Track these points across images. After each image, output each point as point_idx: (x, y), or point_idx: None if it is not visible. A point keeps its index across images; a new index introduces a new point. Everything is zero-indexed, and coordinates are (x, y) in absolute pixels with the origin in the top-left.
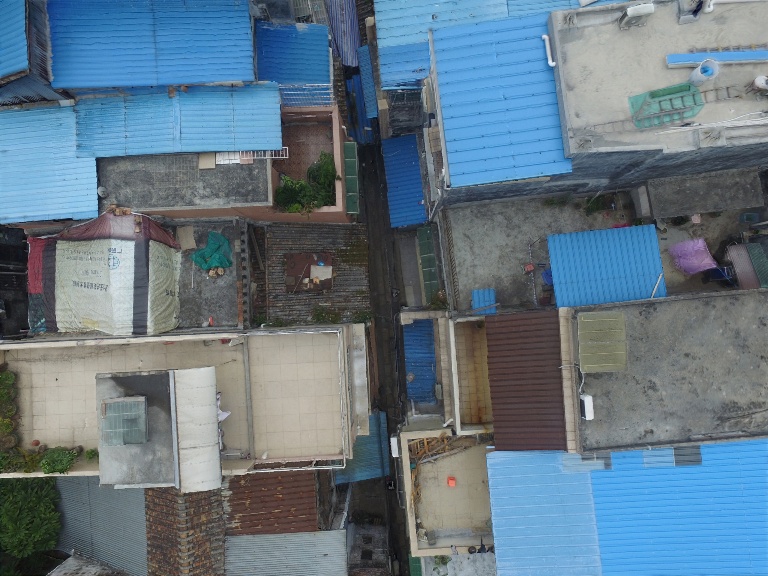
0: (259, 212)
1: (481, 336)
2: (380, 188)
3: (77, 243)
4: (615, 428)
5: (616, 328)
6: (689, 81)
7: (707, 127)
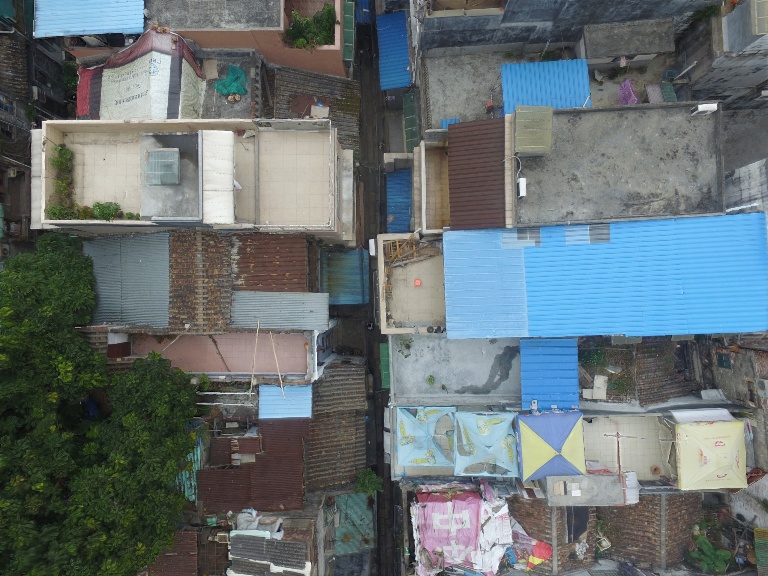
0: (272, 44)
1: None
2: (373, 58)
3: (121, 68)
4: (544, 209)
5: (545, 119)
6: None
7: None
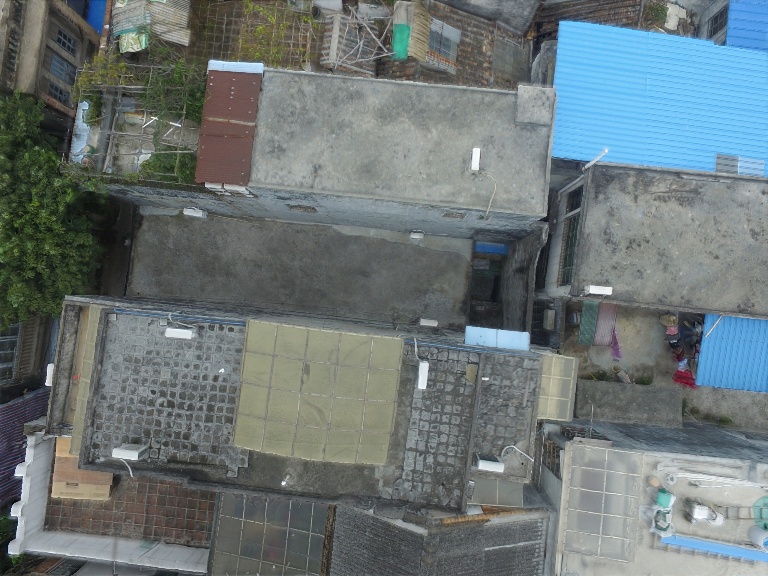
0: None
1: None
2: None
3: None
4: None
5: None
6: None
7: (759, 484)
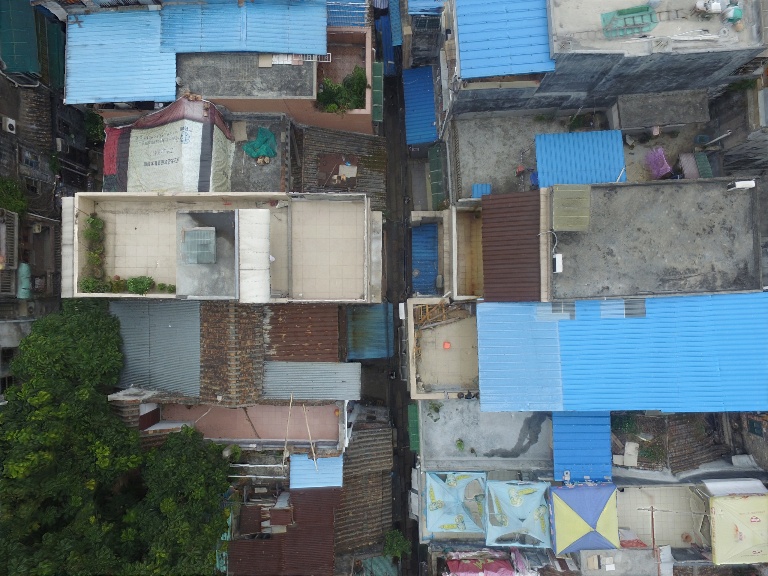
0: (303, 109)
1: (478, 226)
2: (399, 111)
3: (150, 130)
4: (579, 284)
5: (583, 197)
6: (648, 4)
7: None
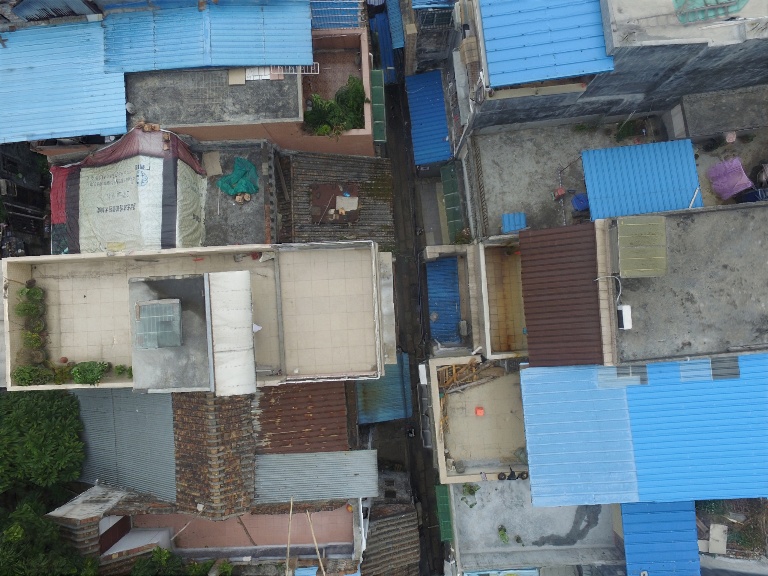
0: (288, 133)
1: (510, 263)
2: (404, 126)
3: (102, 168)
4: (652, 340)
5: (656, 233)
6: None
7: None
